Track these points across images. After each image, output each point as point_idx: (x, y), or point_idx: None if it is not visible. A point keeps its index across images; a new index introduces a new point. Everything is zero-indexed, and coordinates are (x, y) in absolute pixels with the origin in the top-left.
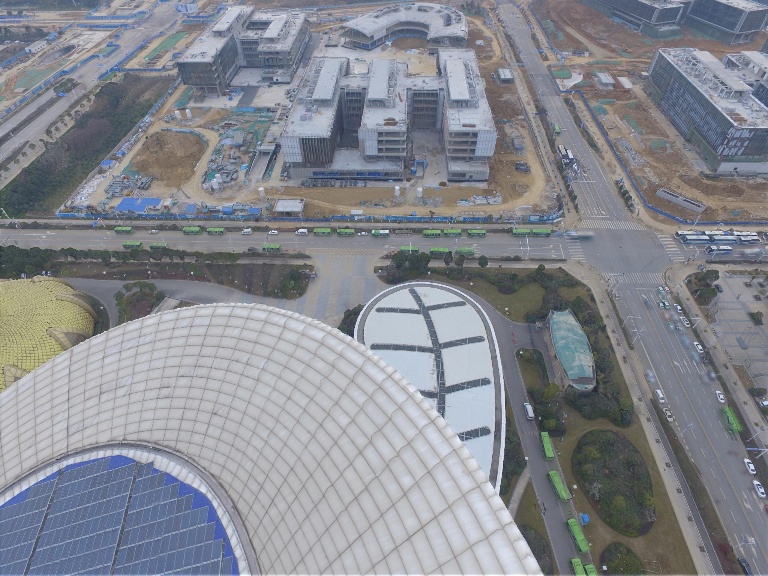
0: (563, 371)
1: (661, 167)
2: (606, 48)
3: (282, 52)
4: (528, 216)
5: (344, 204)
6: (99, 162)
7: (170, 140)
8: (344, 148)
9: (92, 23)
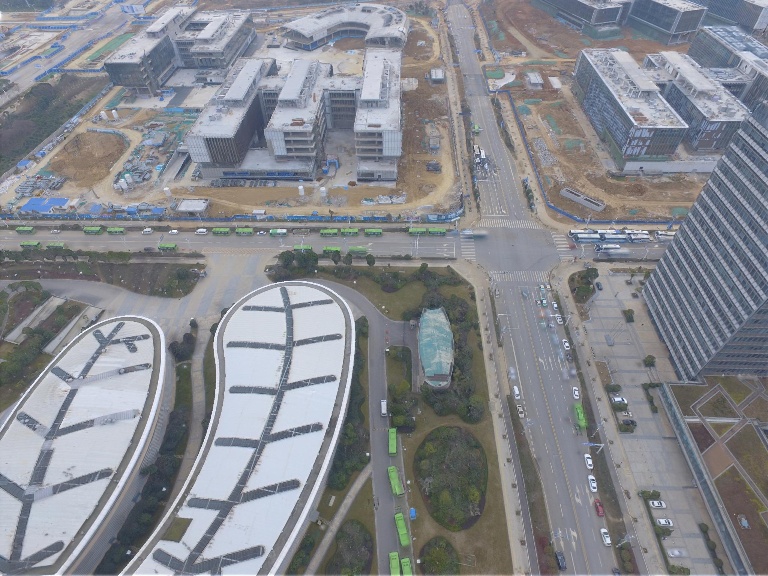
0: None
1: (571, 166)
2: (544, 48)
3: (215, 53)
4: (426, 215)
5: (249, 204)
6: (16, 163)
7: (91, 141)
8: (258, 148)
9: (42, 24)
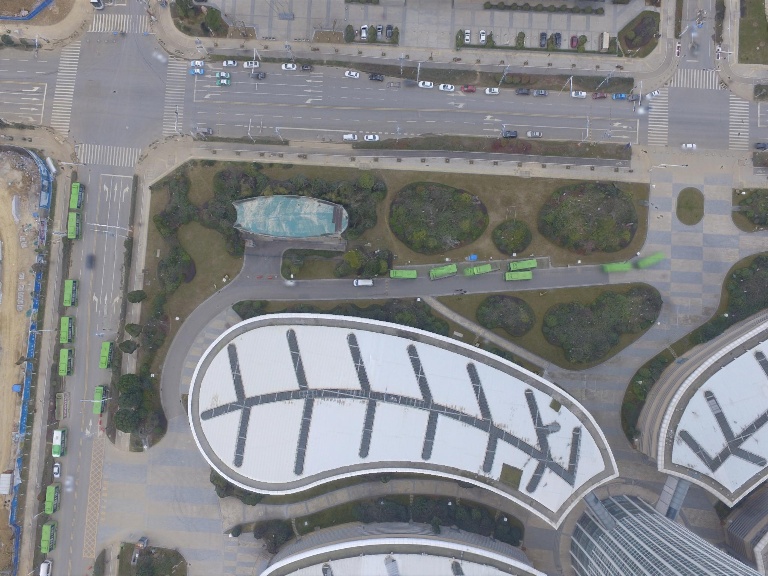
0: None
1: None
2: None
3: None
4: (40, 208)
5: None
6: None
7: None
8: None
9: None
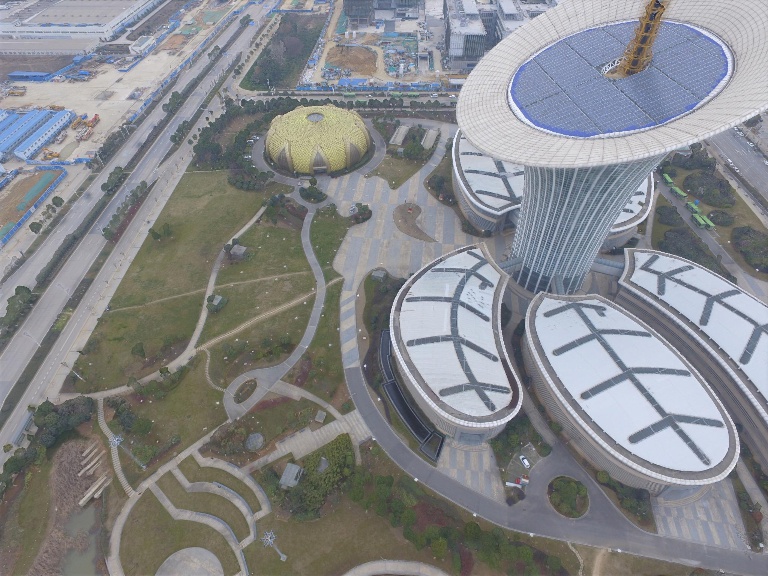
0: None
1: None
2: None
3: None
4: None
5: None
6: (306, 61)
7: (349, 50)
8: (485, 51)
9: None
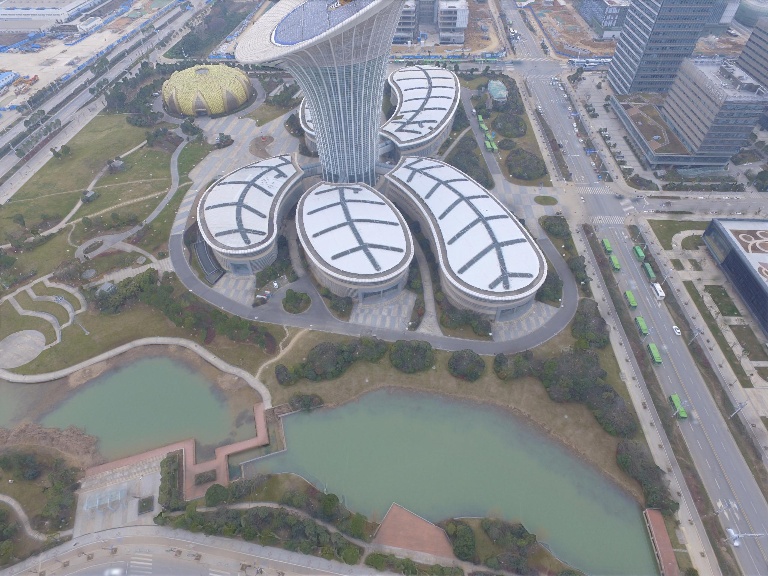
0: (492, 96)
1: (571, 38)
2: None
3: None
4: (485, 54)
5: None
6: (225, 37)
7: None
8: None
9: None
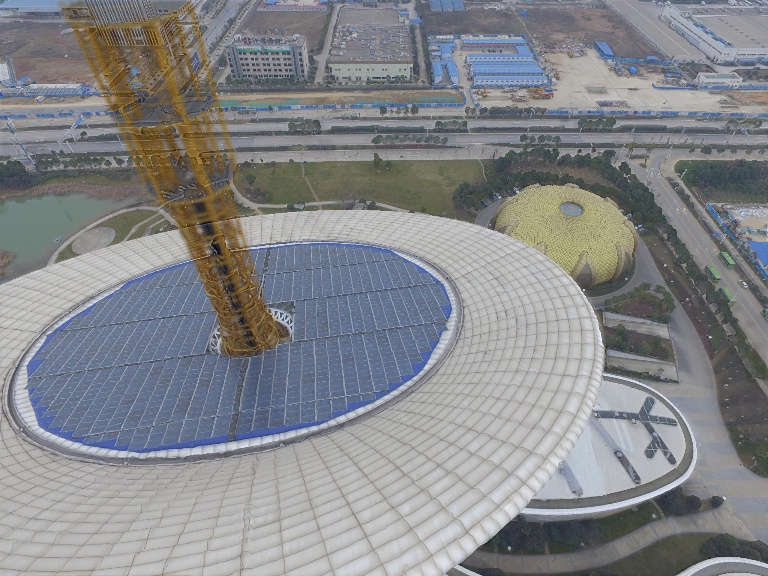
0: None
1: None
2: None
3: None
4: None
5: None
6: None
7: None
8: None
9: None
